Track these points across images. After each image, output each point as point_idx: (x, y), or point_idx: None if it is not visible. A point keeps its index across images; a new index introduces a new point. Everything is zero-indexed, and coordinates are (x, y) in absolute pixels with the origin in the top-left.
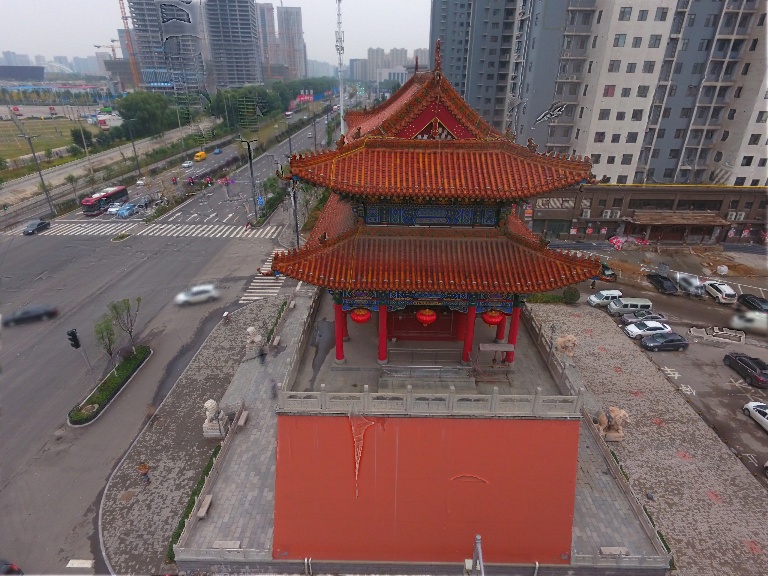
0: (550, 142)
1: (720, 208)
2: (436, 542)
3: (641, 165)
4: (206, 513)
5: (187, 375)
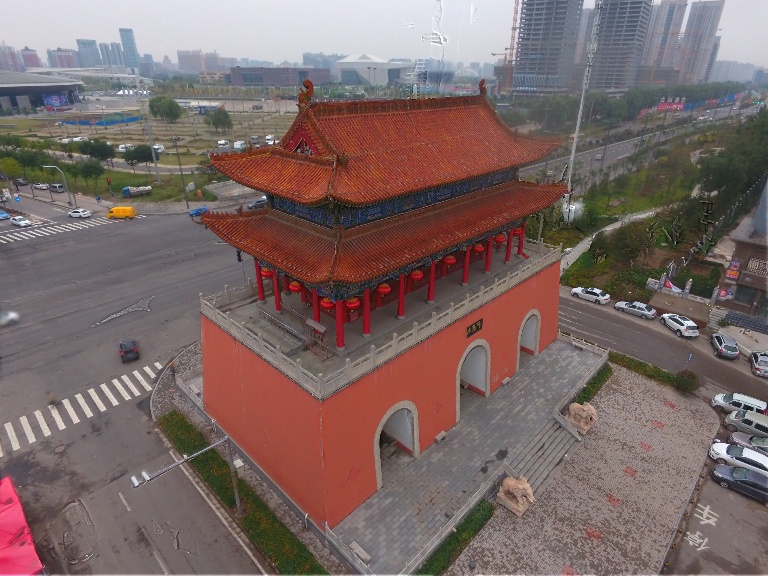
0: None
1: None
2: (262, 453)
3: None
4: None
5: None
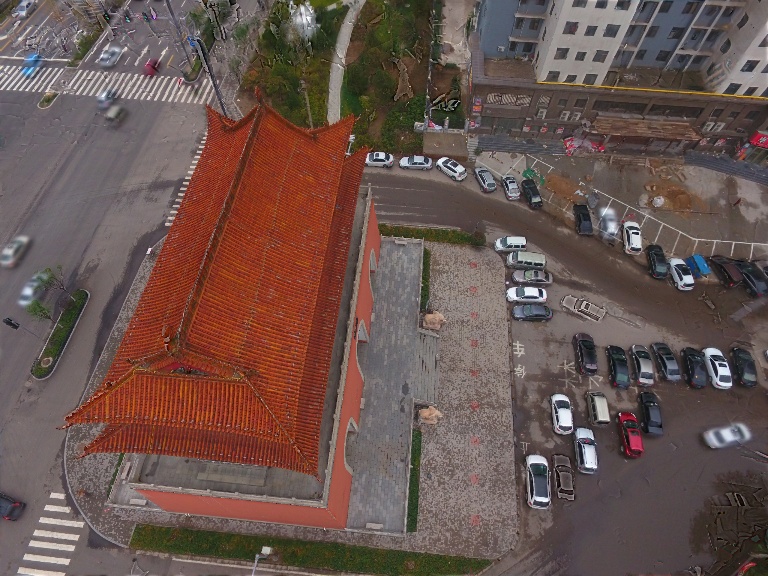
0: (520, 12)
1: (699, 115)
2: (261, 517)
3: (616, 64)
4: (127, 476)
5: (118, 327)
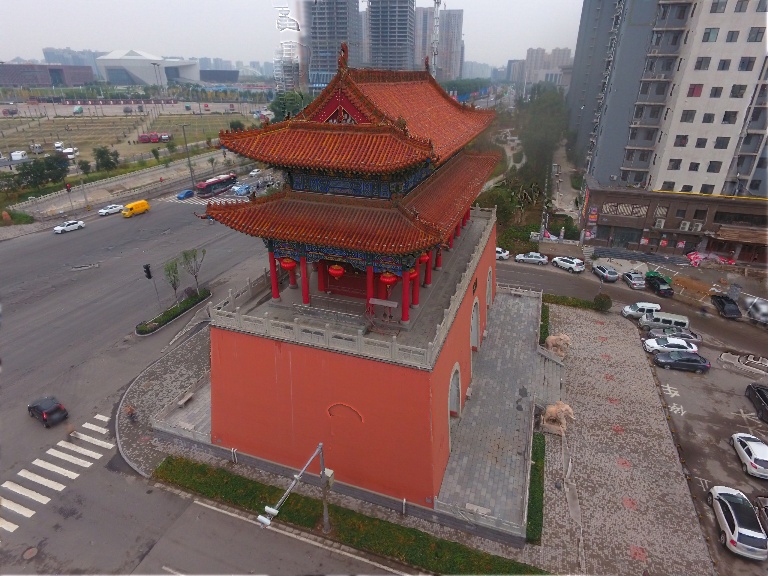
0: (630, 145)
1: None
2: (325, 459)
3: (732, 174)
4: (184, 404)
5: None
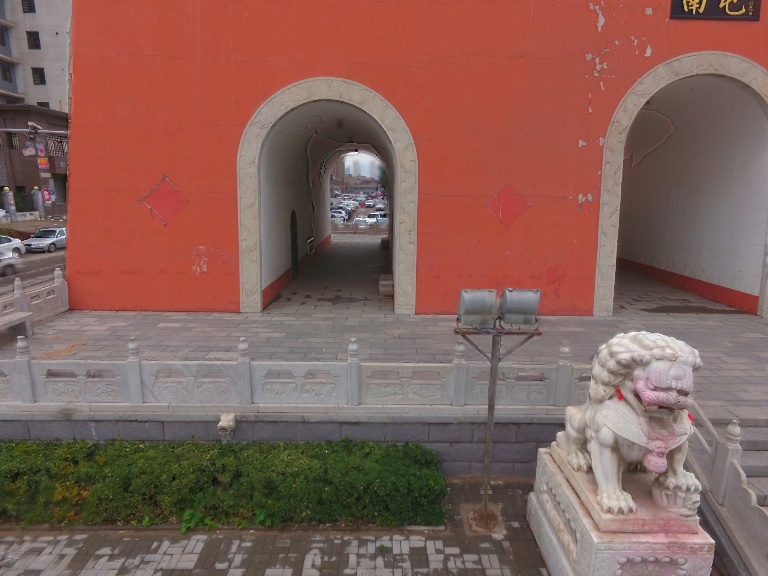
0: None
1: None
2: None
3: None
4: None
5: None
